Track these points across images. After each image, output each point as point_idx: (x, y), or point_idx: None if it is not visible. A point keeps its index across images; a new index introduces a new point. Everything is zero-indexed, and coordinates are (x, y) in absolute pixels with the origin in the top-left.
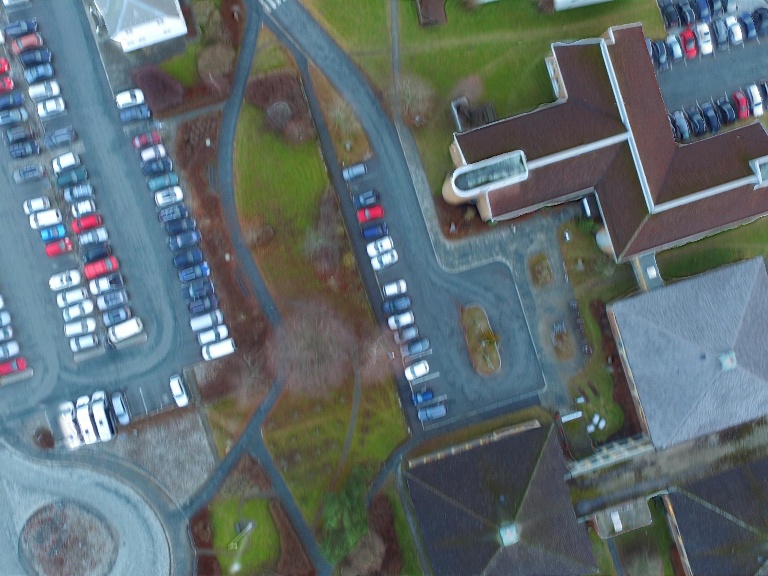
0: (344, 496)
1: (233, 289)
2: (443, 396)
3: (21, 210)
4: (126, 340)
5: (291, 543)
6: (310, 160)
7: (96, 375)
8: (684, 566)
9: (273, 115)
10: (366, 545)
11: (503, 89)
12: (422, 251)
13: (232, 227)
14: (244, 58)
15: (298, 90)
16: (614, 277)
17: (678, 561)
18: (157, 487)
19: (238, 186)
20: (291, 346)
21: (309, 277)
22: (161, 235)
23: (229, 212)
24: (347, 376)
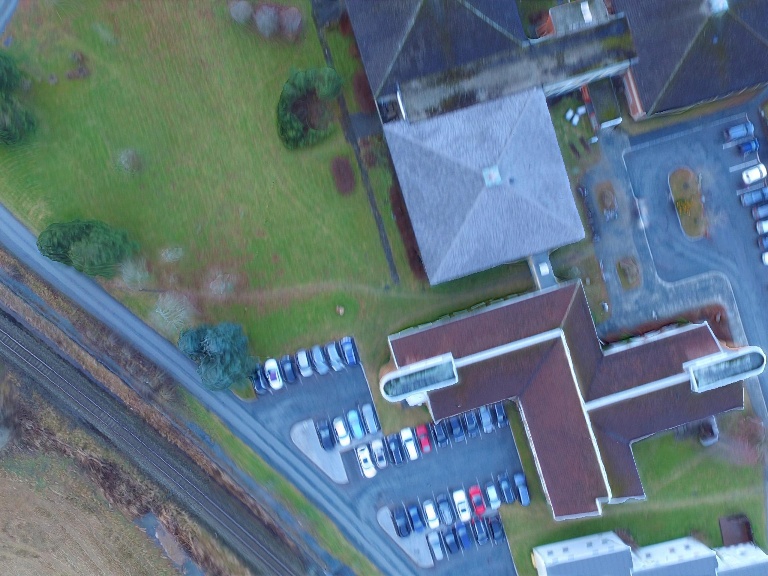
0: None
1: None
2: (727, 147)
3: None
4: None
5: None
6: None
7: None
8: None
9: None
10: None
11: (664, 454)
12: (746, 293)
13: None
14: None
15: None
16: (557, 265)
17: None
18: None
19: None
20: None
21: None
22: None
23: None
24: None
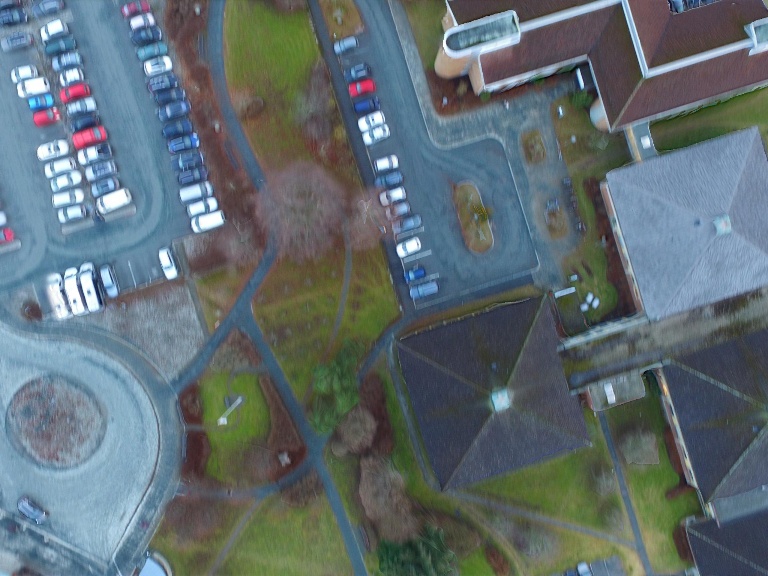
0: (334, 365)
1: (223, 161)
2: (435, 274)
3: (9, 79)
4: (115, 212)
5: (281, 417)
6: (301, 31)
7: (84, 248)
8: (678, 448)
9: None
10: (357, 419)
11: None
12: (414, 127)
13: (222, 99)
14: None
15: None
16: (608, 154)
17: (672, 443)
18: (146, 362)
19: (228, 57)
20: (281, 218)
21: (300, 150)
22: (150, 106)
23: (219, 83)
24: (338, 250)
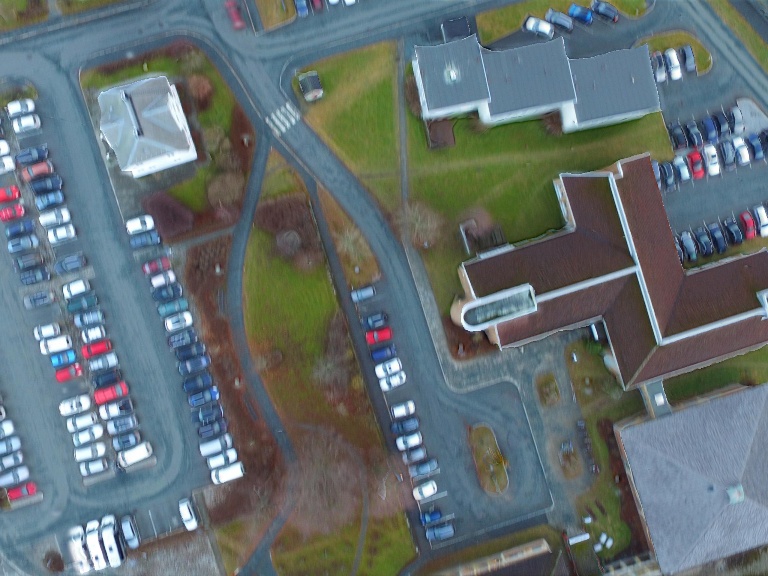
0: None
1: (242, 413)
2: (451, 515)
3: (31, 335)
4: (136, 464)
5: None
6: (319, 284)
7: (106, 498)
8: None
9: (283, 246)
10: None
11: (511, 211)
12: (430, 371)
13: (241, 351)
14: (253, 182)
15: (307, 215)
16: (621, 397)
17: None
18: None
19: (247, 310)
20: (300, 470)
21: (318, 400)
22: (171, 359)
23: (238, 336)
24: (355, 498)
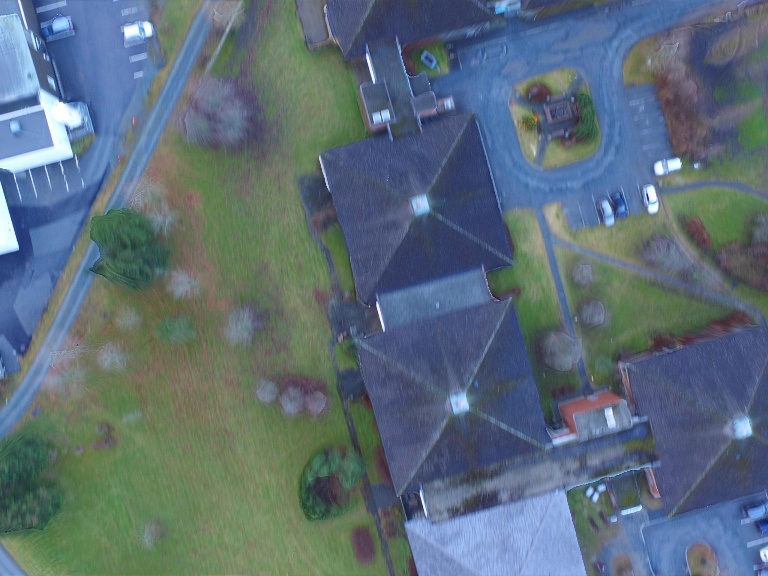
0: None
1: None
2: (746, 523)
3: None
4: None
5: None
6: None
7: None
8: None
9: None
10: None
11: None
12: None
13: None
14: None
15: None
16: None
17: None
18: None
19: None
20: None
21: None
22: None
23: None
24: None
